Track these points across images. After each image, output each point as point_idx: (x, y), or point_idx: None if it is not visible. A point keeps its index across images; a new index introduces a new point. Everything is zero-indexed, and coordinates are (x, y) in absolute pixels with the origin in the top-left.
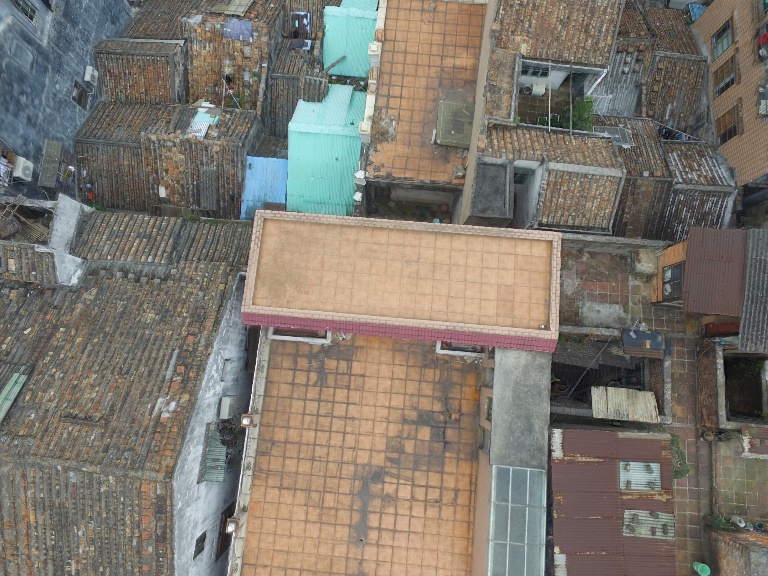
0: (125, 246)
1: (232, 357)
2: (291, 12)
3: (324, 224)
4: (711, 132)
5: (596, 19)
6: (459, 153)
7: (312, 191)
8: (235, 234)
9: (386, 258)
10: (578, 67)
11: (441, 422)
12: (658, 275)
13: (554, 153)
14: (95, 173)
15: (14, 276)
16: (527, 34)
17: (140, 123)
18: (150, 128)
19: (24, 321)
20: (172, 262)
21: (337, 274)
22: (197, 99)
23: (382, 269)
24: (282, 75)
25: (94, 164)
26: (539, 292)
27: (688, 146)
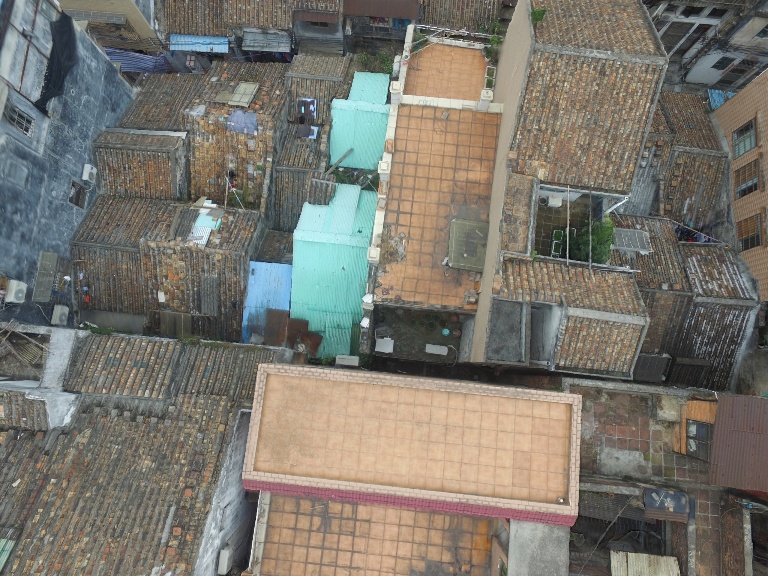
0: (121, 377)
1: (232, 498)
2: (297, 98)
3: (330, 380)
4: (732, 234)
5: (618, 146)
6: (472, 276)
7: (317, 299)
8: (236, 361)
9: (396, 418)
10: (598, 193)
11: (450, 574)
12: (681, 425)
13: (573, 294)
14: (92, 276)
15: (3, 421)
16: (545, 159)
17: (139, 222)
18: (150, 233)
19: (13, 470)
20: (170, 396)
21: (344, 436)
22: (199, 190)
23: (391, 431)
24: (287, 168)
25: (91, 267)
26: (557, 460)
27: (708, 249)
